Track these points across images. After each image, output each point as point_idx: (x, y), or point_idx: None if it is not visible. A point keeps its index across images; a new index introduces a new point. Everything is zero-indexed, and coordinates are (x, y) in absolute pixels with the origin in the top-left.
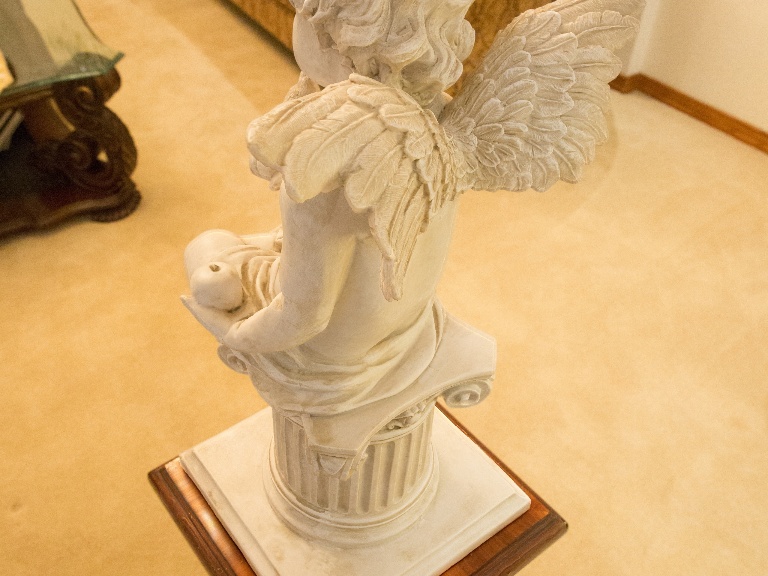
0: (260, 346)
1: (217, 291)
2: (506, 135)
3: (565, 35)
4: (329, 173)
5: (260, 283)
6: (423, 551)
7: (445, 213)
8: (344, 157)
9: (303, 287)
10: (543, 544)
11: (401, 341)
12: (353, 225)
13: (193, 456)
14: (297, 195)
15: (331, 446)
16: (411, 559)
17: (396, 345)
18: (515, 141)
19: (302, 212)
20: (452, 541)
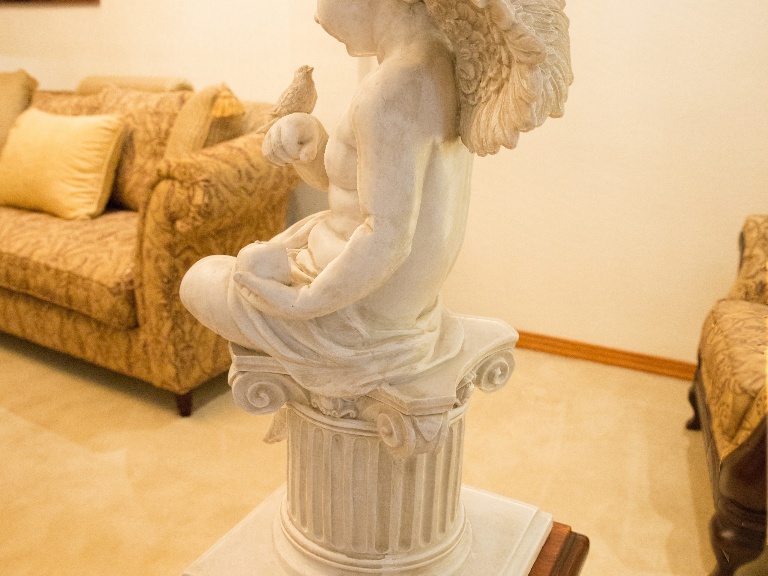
0: (346, 289)
1: (276, 258)
2: None
3: None
4: None
5: (297, 268)
6: None
7: None
8: None
9: (395, 197)
10: (578, 561)
11: (434, 317)
12: (433, 126)
13: None
14: None
15: (430, 397)
16: None
17: (432, 320)
18: None
19: (391, 112)
20: (511, 563)
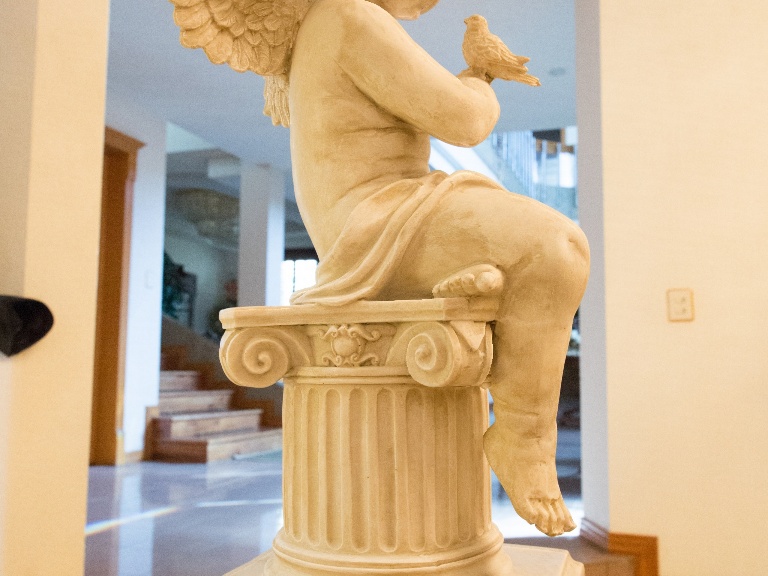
0: None
1: None
2: None
3: None
4: None
5: None
6: (248, 565)
7: None
8: None
9: None
10: None
11: None
12: None
13: None
14: None
15: None
16: (257, 560)
17: None
18: None
19: None
20: None
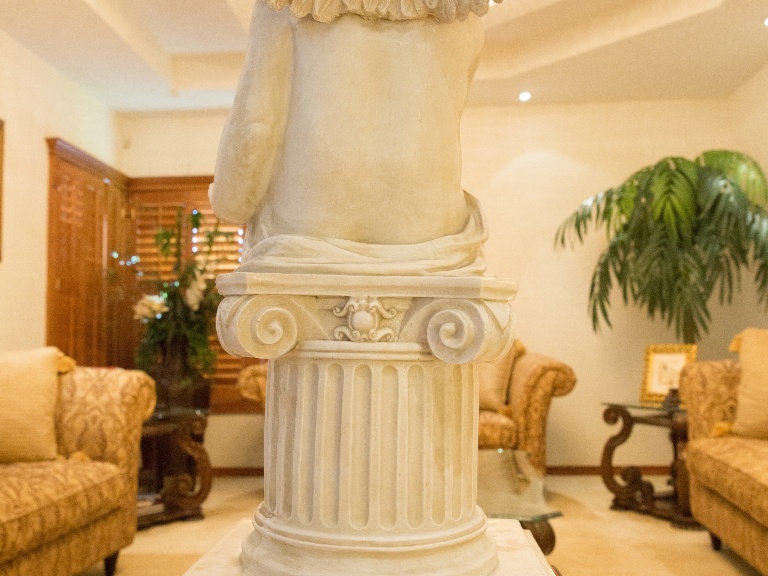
0: (216, 172)
1: None
2: None
3: None
4: None
5: None
6: None
7: (406, 42)
8: None
9: (242, 76)
10: None
11: (387, 249)
12: (286, 8)
13: None
14: None
15: None
16: None
17: (378, 249)
18: None
19: None
20: None
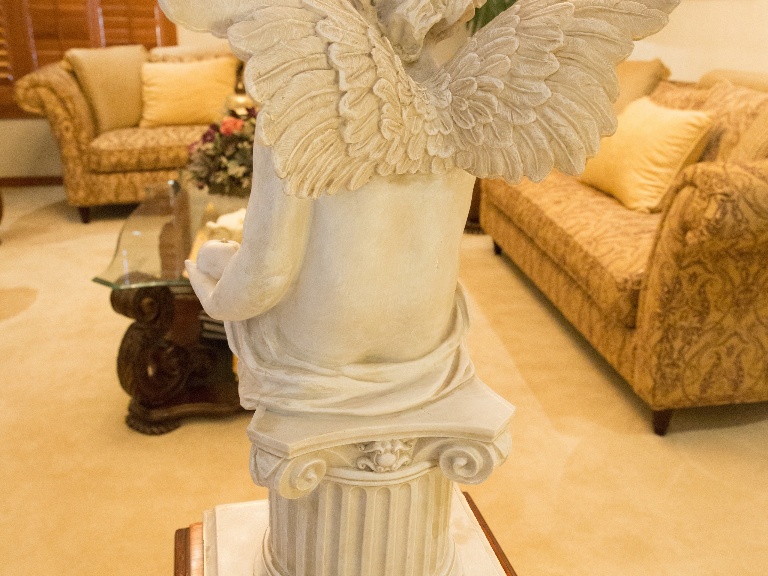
0: (222, 300)
1: (214, 257)
2: (481, 91)
3: (561, 3)
4: (218, 14)
5: None
6: None
7: (430, 194)
8: (240, 7)
9: (255, 223)
10: None
11: (395, 370)
12: None
13: (213, 512)
14: (165, 6)
15: (265, 434)
16: None
17: (388, 371)
18: (490, 99)
19: None
20: None
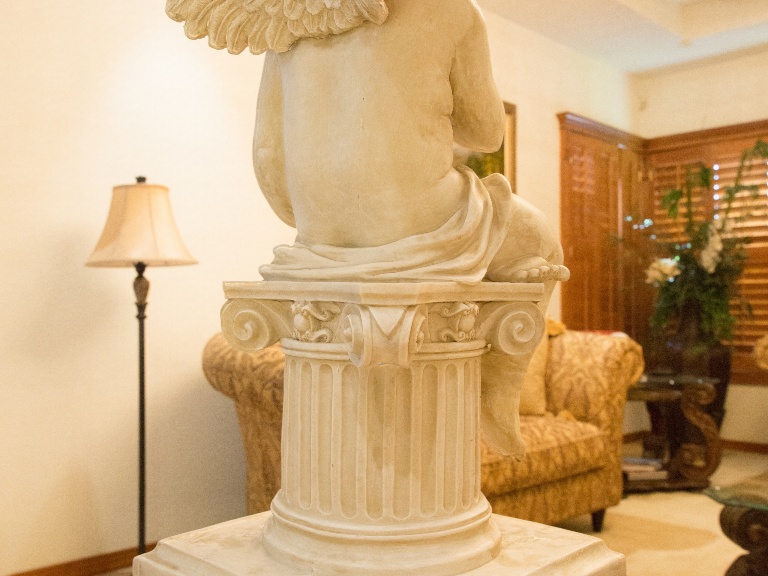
0: None
1: None
2: None
3: None
4: None
5: None
6: None
7: (349, 53)
8: None
9: None
10: None
11: (355, 252)
12: None
13: None
14: None
15: None
16: (251, 573)
17: (348, 253)
18: None
19: None
20: None
